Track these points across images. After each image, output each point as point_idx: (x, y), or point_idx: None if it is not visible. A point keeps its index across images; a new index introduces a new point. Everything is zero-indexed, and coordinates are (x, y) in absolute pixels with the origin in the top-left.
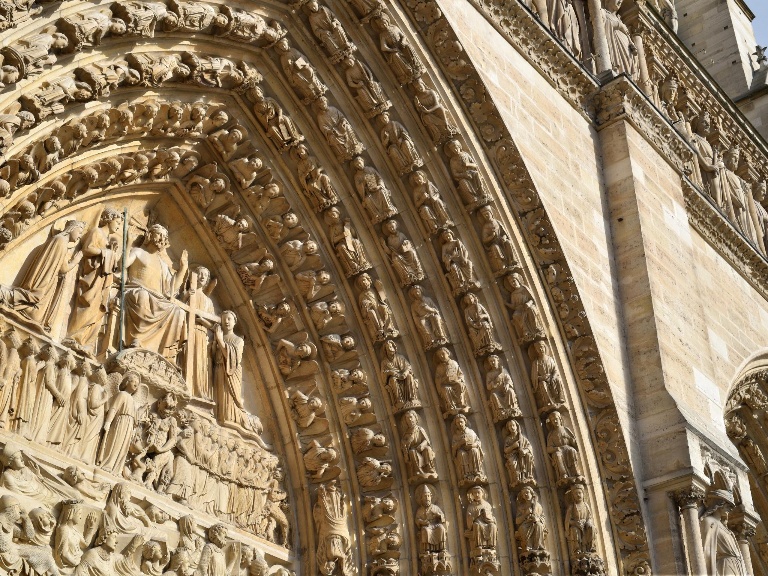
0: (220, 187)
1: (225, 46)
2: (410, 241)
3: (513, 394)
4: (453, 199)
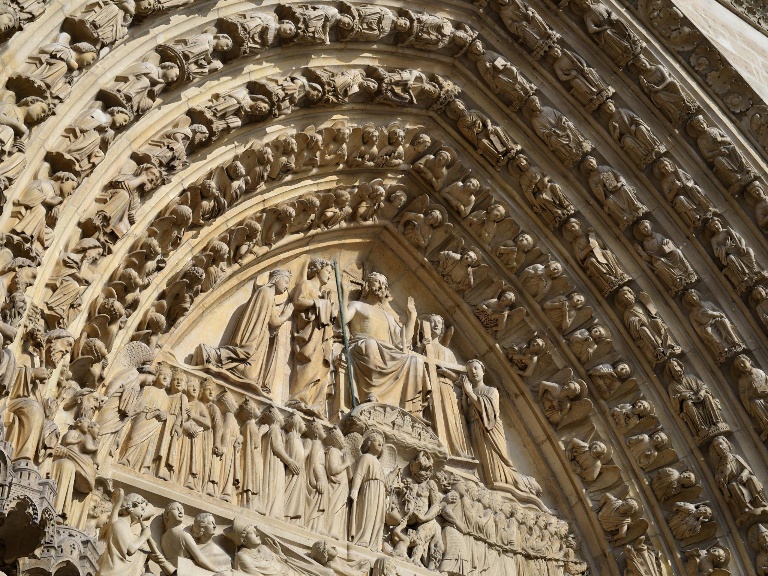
0: (436, 219)
1: (412, 58)
2: (670, 241)
3: None
4: (711, 185)
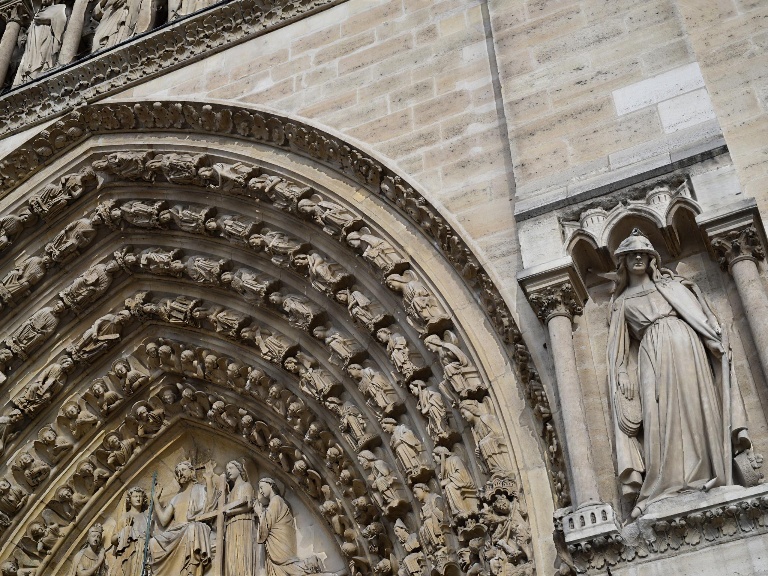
0: (186, 397)
1: (100, 308)
2: (296, 295)
3: (397, 358)
4: (296, 222)
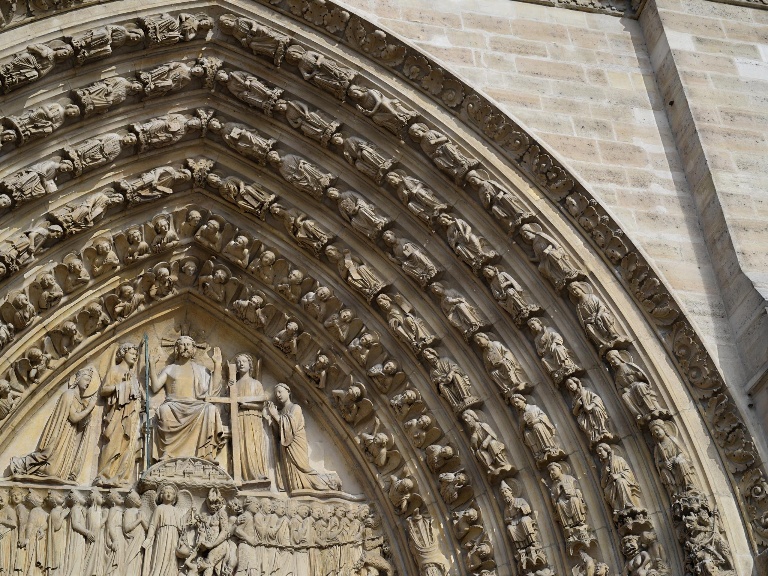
0: (220, 278)
1: (159, 156)
2: (414, 243)
3: (560, 351)
4: (441, 181)
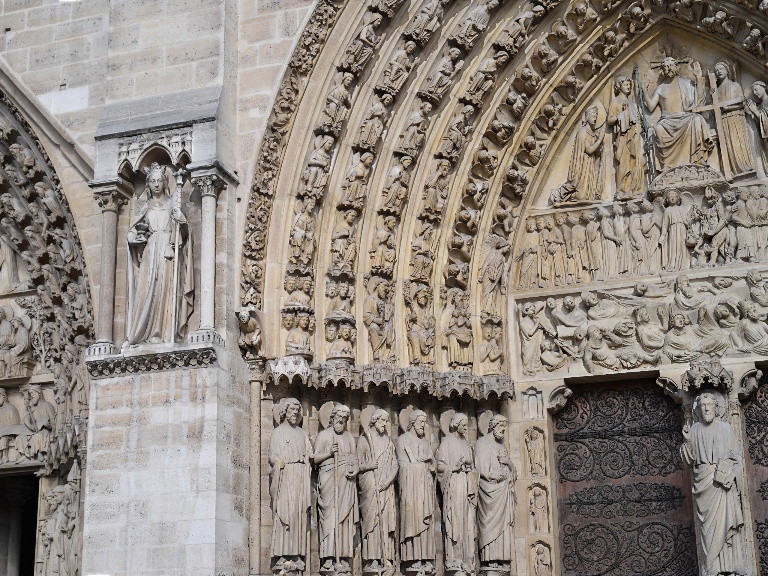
0: (685, 4)
1: None
2: None
3: None
4: None
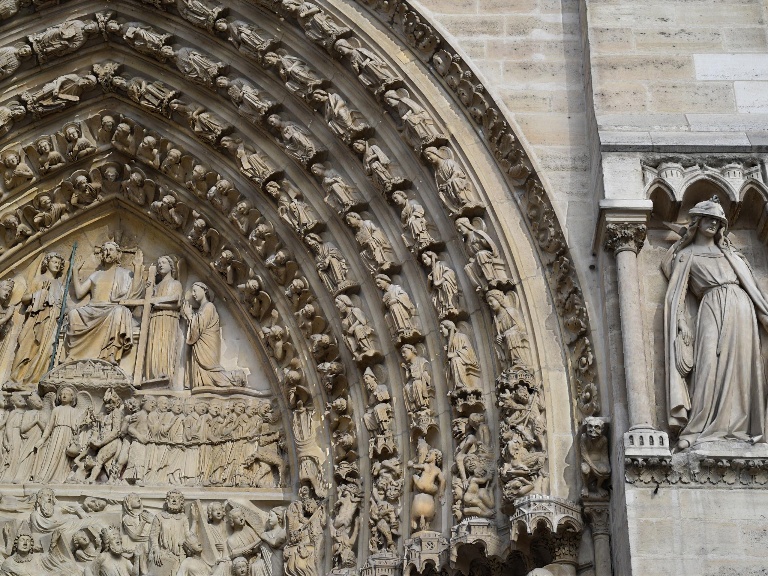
0: (134, 181)
1: (64, 65)
2: (298, 124)
3: (415, 225)
4: (320, 56)
